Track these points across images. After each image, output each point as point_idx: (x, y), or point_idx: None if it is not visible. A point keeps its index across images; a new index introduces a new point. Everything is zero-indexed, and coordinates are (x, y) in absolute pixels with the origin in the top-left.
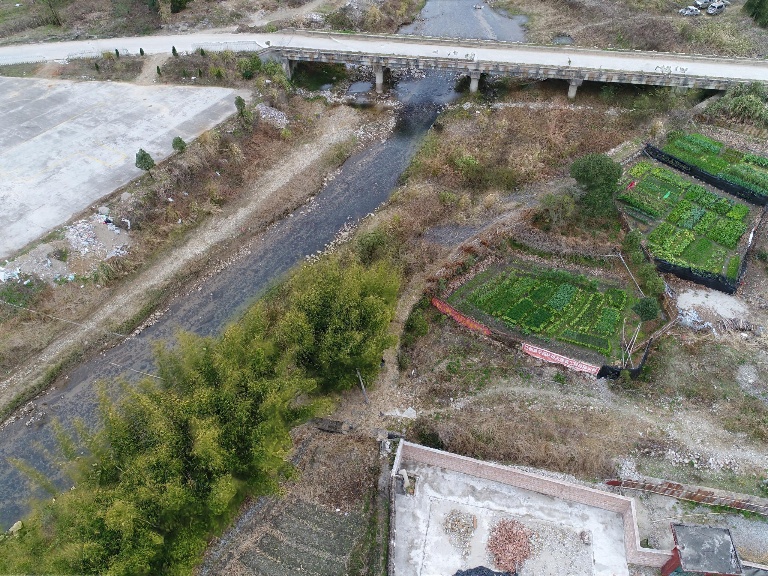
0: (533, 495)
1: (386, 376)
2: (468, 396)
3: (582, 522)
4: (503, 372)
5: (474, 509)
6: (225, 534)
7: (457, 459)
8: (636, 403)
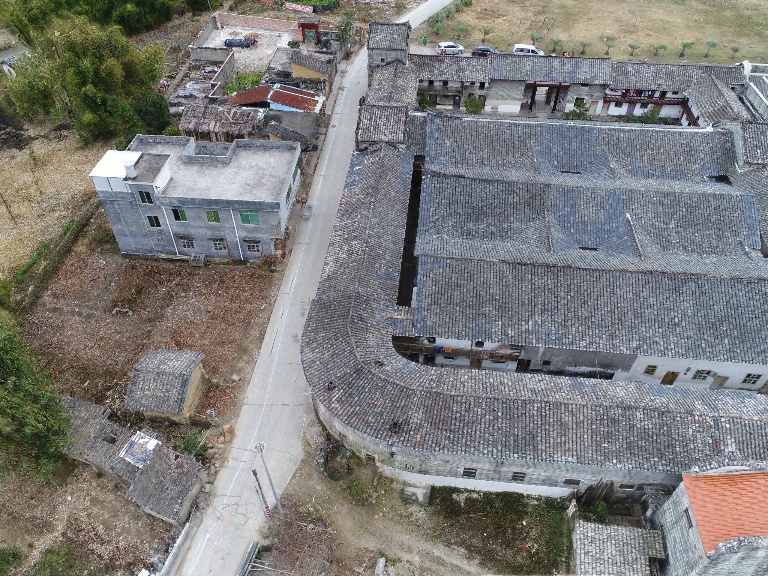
0: (267, 30)
1: (223, 9)
2: (255, 14)
3: (281, 34)
4: (273, 10)
5: (242, 31)
6: (149, 35)
7: (238, 17)
8: (323, 16)
